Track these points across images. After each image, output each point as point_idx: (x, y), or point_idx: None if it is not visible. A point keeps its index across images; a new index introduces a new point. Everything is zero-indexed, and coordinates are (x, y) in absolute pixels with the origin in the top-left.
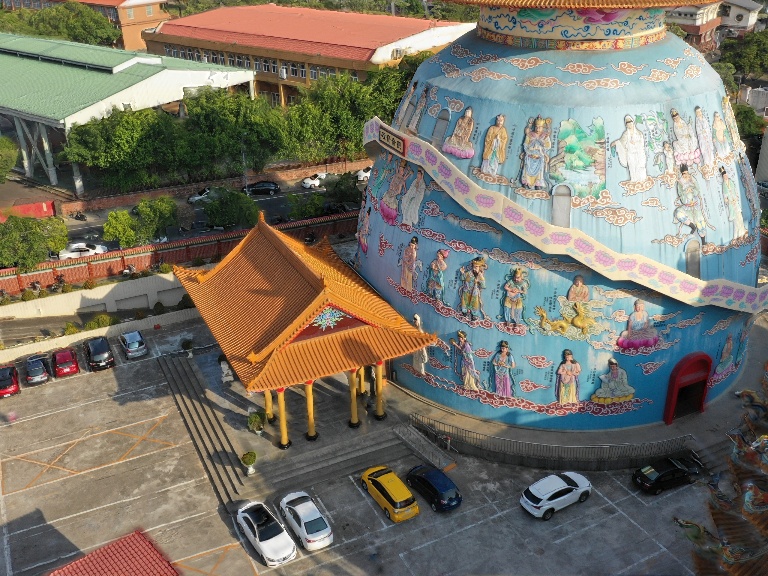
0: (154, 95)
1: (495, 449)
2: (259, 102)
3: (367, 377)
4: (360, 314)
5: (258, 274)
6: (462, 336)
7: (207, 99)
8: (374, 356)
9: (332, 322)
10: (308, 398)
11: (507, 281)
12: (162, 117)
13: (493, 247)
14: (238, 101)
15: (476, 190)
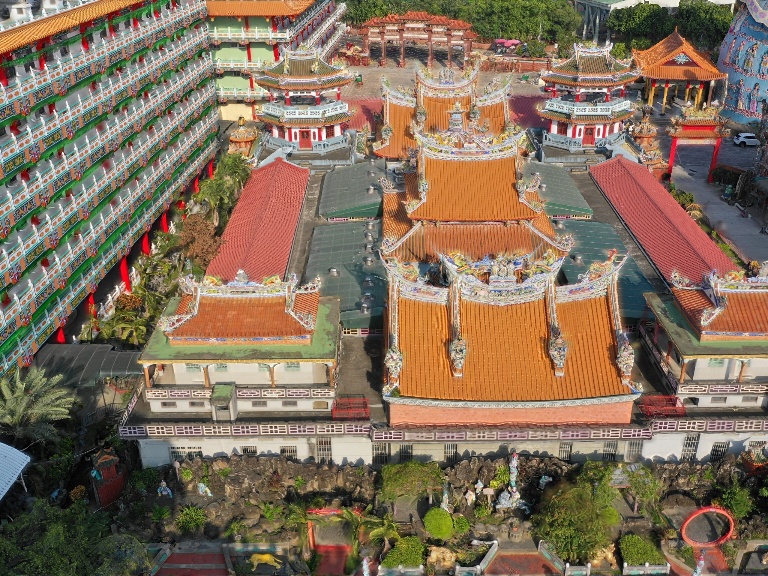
0: (665, 1)
1: (738, 129)
2: (724, 8)
3: (701, 108)
4: (696, 60)
5: (664, 48)
6: (741, 81)
7: (692, 2)
8: (696, 77)
9: (683, 61)
10: (665, 94)
11: (765, 54)
12: (662, 7)
13: (763, 38)
14: (710, 5)
15: (760, 10)
